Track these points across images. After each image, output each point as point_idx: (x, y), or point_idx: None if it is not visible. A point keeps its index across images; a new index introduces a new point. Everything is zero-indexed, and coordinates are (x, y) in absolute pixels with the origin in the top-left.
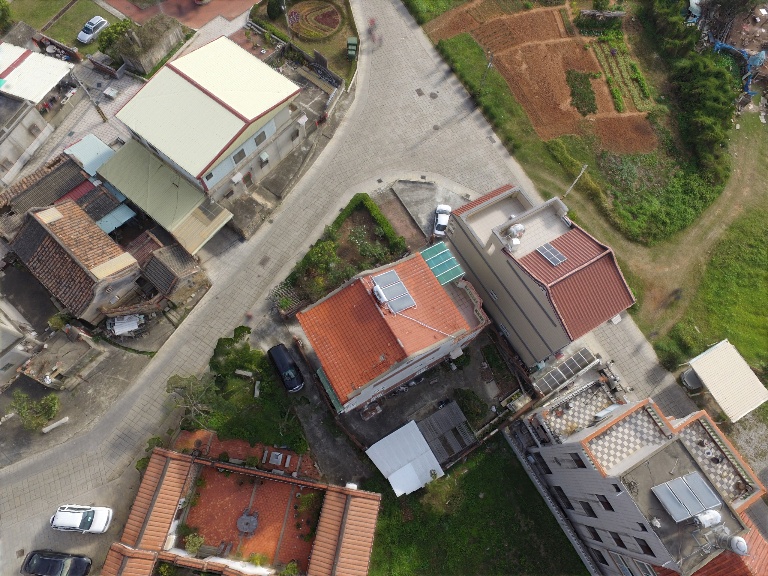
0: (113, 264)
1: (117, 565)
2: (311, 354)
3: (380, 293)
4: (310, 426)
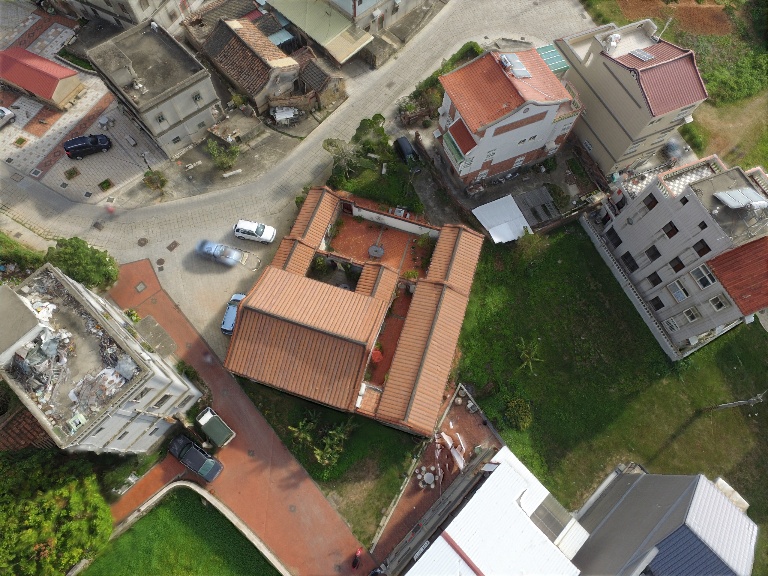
0: (282, 62)
1: (290, 246)
2: (427, 150)
3: (507, 60)
4: (425, 198)
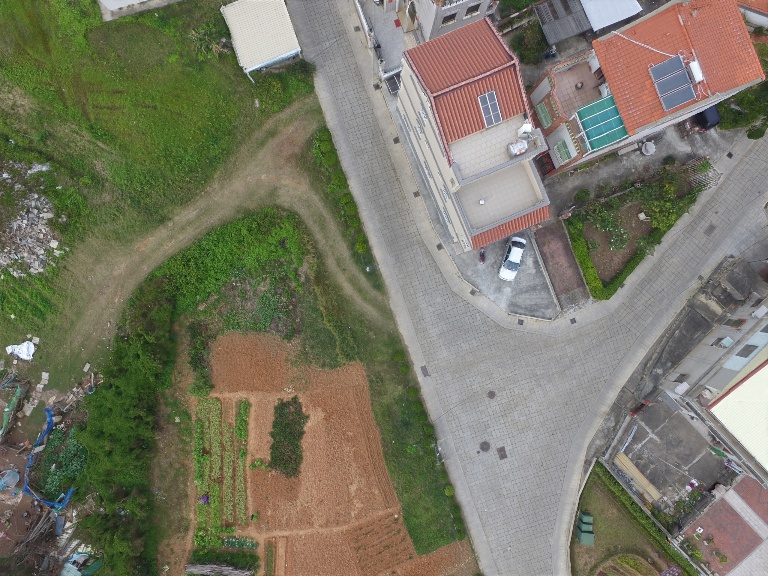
0: None
1: None
2: None
3: (697, 72)
4: None
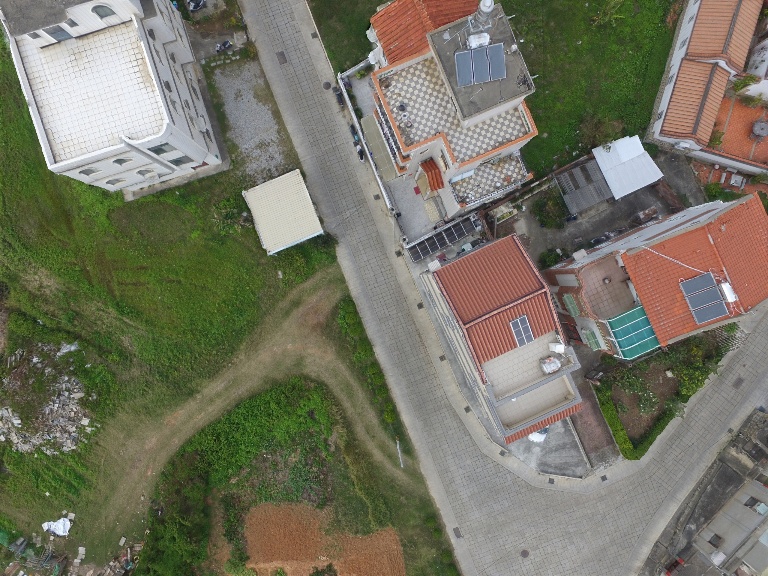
0: None
1: None
2: None
3: (730, 293)
4: None
